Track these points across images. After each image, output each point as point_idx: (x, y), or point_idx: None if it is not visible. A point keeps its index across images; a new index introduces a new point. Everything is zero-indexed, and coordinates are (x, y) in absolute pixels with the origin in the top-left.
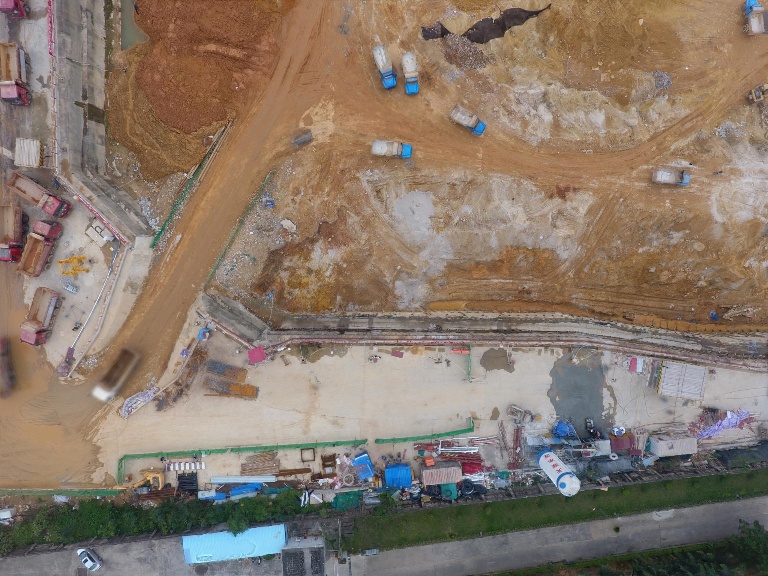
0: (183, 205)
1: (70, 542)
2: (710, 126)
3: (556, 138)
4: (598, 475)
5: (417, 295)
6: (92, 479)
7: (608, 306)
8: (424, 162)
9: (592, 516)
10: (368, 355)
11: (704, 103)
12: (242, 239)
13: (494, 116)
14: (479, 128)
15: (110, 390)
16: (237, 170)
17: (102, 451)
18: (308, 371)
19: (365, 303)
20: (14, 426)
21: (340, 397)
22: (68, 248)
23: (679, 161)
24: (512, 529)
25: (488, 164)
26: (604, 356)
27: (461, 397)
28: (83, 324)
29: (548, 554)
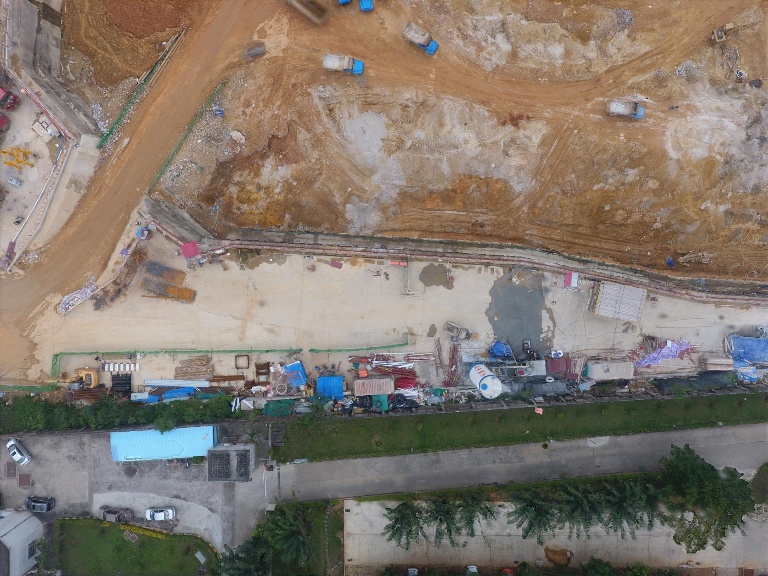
0: (133, 109)
1: None
2: (670, 64)
3: (511, 64)
4: (531, 395)
5: (369, 223)
6: (27, 376)
7: (563, 245)
8: (376, 80)
9: (525, 438)
10: (307, 264)
11: (665, 41)
12: (190, 146)
13: (448, 37)
14: (432, 47)
15: (49, 287)
16: (188, 78)
17: (38, 348)
18: (246, 277)
19: (315, 224)
20: None
21: (277, 305)
22: (14, 142)
23: (635, 95)
24: (444, 447)
25: (440, 85)
26: (545, 278)
27: (398, 312)
28: (25, 219)
29: (479, 475)
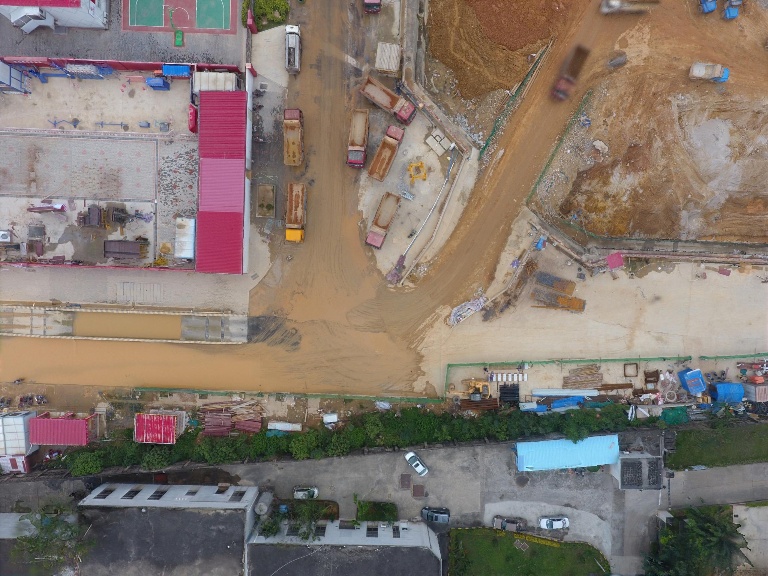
0: (506, 121)
1: (404, 445)
2: None
3: None
4: None
5: (691, 228)
6: (413, 387)
7: None
8: (735, 88)
9: None
10: (695, 272)
11: None
12: (560, 157)
13: None
14: None
15: (438, 299)
16: (557, 89)
17: (424, 360)
18: (635, 286)
19: (651, 231)
20: (340, 332)
21: (665, 313)
22: (406, 156)
23: None
24: None
25: None
26: None
27: None
28: (417, 232)
29: None
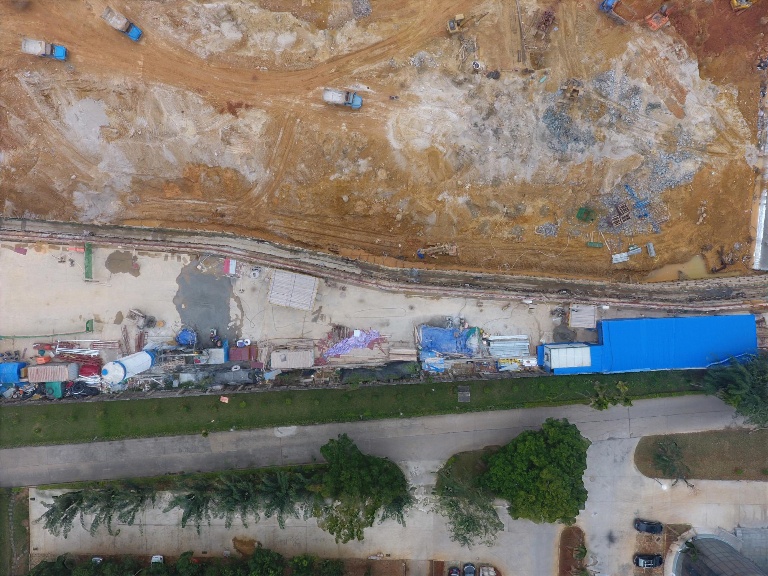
0: None
1: None
2: (404, 55)
3: (226, 52)
4: (209, 383)
5: (108, 211)
6: None
7: (310, 236)
8: (84, 66)
9: (210, 428)
10: None
11: (400, 32)
12: None
13: (154, 23)
14: (133, 33)
15: None
16: None
17: None
18: None
19: (41, 212)
20: None
21: None
22: None
23: (357, 84)
24: (128, 436)
25: (150, 72)
26: None
27: (84, 298)
28: None
29: (166, 464)
